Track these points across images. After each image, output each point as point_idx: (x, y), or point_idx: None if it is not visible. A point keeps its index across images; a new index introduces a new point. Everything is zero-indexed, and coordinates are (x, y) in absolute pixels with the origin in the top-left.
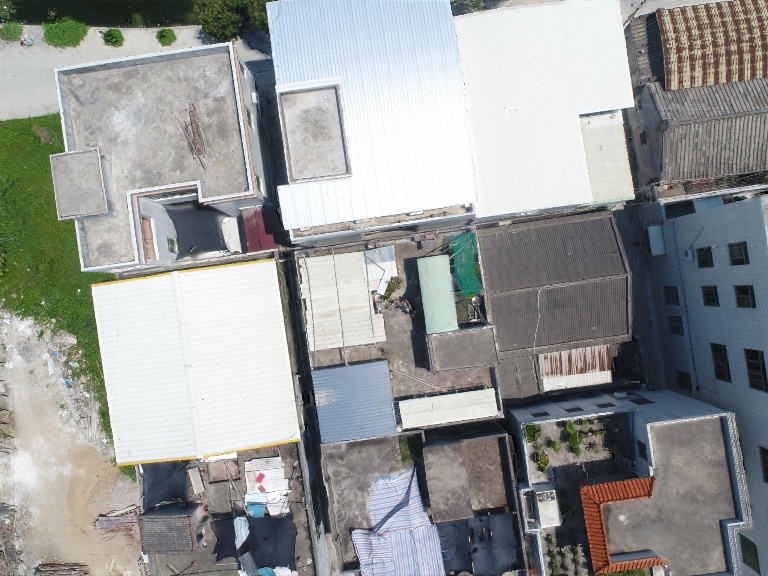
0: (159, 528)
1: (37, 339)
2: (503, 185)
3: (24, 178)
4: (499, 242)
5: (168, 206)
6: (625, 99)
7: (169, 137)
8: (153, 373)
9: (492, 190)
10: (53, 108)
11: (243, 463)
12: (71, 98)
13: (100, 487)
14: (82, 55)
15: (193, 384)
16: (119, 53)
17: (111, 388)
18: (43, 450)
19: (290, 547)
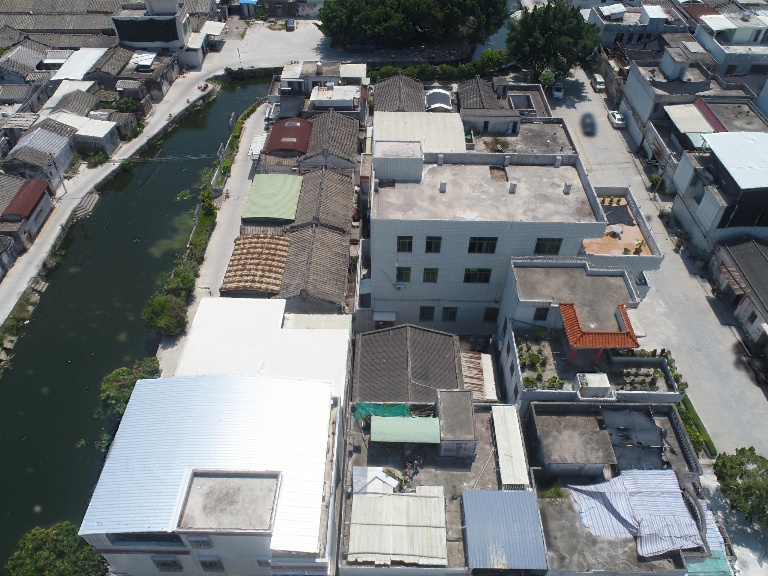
0: None
1: None
2: None
3: None
4: None
5: None
6: (279, 303)
7: None
8: None
9: None
10: None
11: None
12: None
13: None
14: None
15: None
16: None
17: None
18: None
19: None
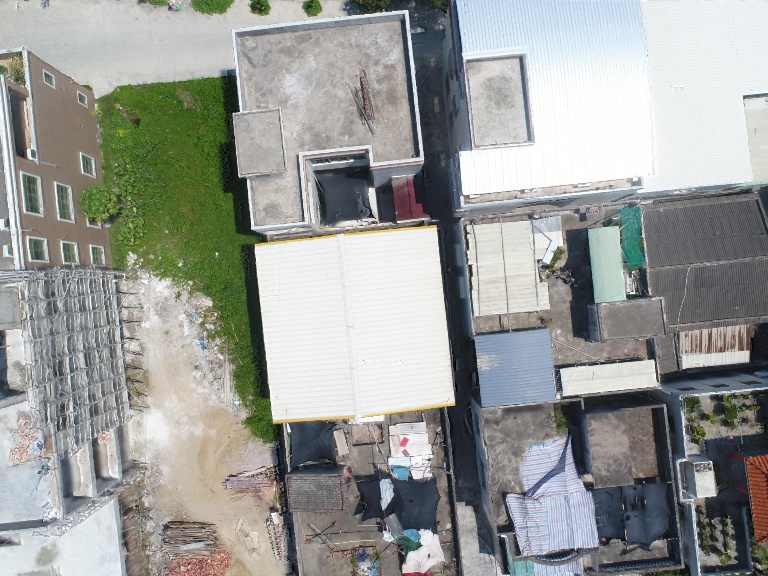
0: (308, 486)
1: (175, 300)
2: (666, 162)
3: (166, 141)
4: (647, 220)
5: (319, 172)
6: None
7: (339, 102)
8: (314, 333)
9: (655, 166)
10: (198, 73)
11: (387, 427)
12: (244, 60)
13: (232, 448)
14: (228, 22)
15: (355, 345)
16: (265, 21)
17: (270, 346)
18: (176, 409)
19: (433, 511)
